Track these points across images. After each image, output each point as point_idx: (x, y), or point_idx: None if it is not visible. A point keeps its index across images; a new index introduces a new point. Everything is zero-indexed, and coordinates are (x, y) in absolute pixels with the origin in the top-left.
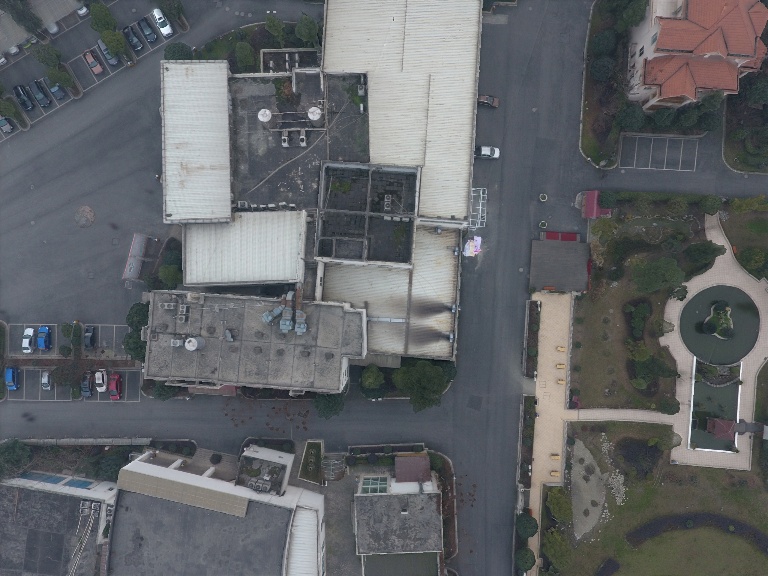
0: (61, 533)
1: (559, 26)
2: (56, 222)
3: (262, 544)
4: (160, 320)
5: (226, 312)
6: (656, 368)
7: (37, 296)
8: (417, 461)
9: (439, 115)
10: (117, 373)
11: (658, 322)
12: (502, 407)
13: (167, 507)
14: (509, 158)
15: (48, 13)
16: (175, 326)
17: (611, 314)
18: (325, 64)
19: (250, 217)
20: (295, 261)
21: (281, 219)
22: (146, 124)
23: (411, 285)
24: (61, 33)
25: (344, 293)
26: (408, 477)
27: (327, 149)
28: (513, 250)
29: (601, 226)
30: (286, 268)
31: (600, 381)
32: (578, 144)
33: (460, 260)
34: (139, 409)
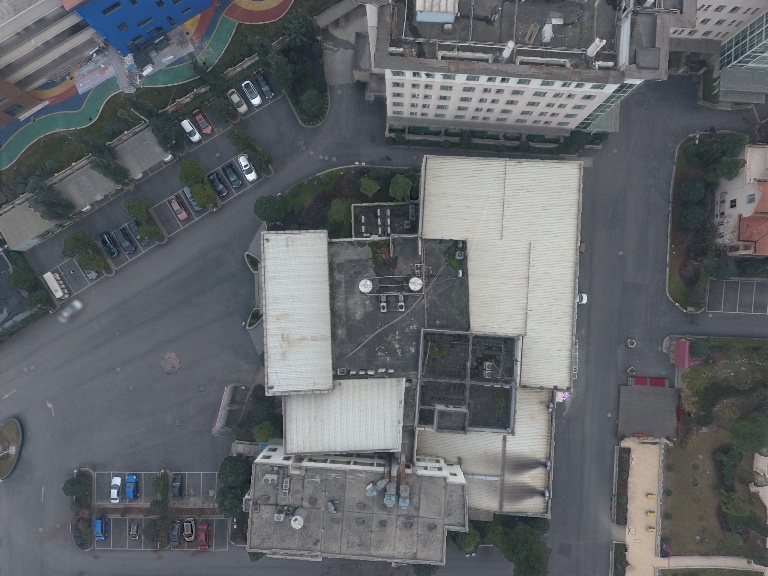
0: None
1: (644, 168)
2: (142, 369)
3: None
4: (261, 491)
5: (327, 482)
6: (753, 525)
7: (123, 444)
8: None
9: (540, 284)
10: (205, 522)
11: (752, 475)
12: (592, 554)
13: None
14: (596, 302)
15: (135, 163)
16: (276, 497)
17: (700, 460)
18: (424, 231)
19: (350, 385)
20: (396, 430)
21: (381, 386)
22: (231, 269)
23: (505, 441)
24: (145, 178)
25: (437, 448)
26: None
27: (425, 313)
28: (601, 395)
29: (694, 378)
30: (387, 437)
31: (690, 527)
32: (665, 288)
33: (554, 416)
34: (227, 557)
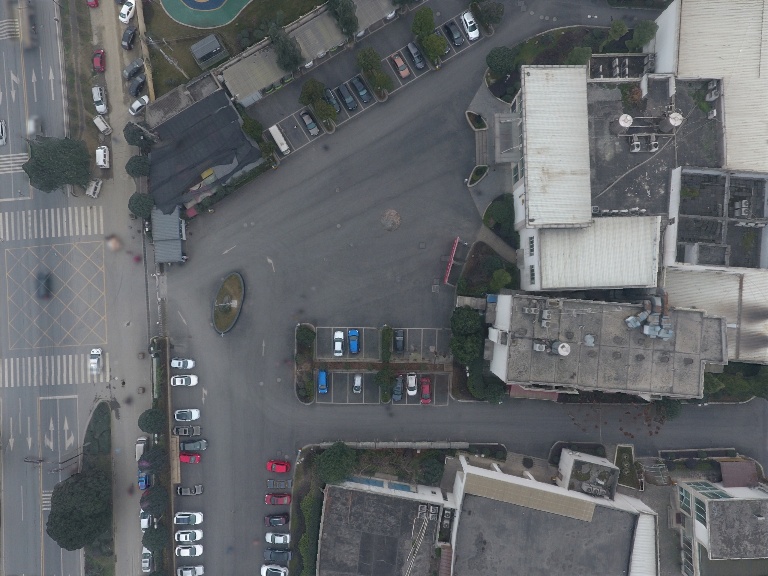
0: (395, 536)
1: None
2: (362, 225)
3: (605, 548)
4: (519, 325)
5: (584, 317)
6: None
7: (344, 299)
8: (743, 466)
9: None
10: (428, 377)
11: None
12: None
13: (510, 511)
14: None
15: (363, 16)
16: (533, 331)
17: None
18: (679, 70)
19: (603, 222)
20: (650, 266)
21: (634, 224)
22: (452, 128)
23: (742, 290)
24: (365, 36)
25: (670, 298)
26: (736, 482)
27: (675, 154)
28: None
29: None
30: (642, 273)
31: None
32: None
33: None
34: (447, 413)
